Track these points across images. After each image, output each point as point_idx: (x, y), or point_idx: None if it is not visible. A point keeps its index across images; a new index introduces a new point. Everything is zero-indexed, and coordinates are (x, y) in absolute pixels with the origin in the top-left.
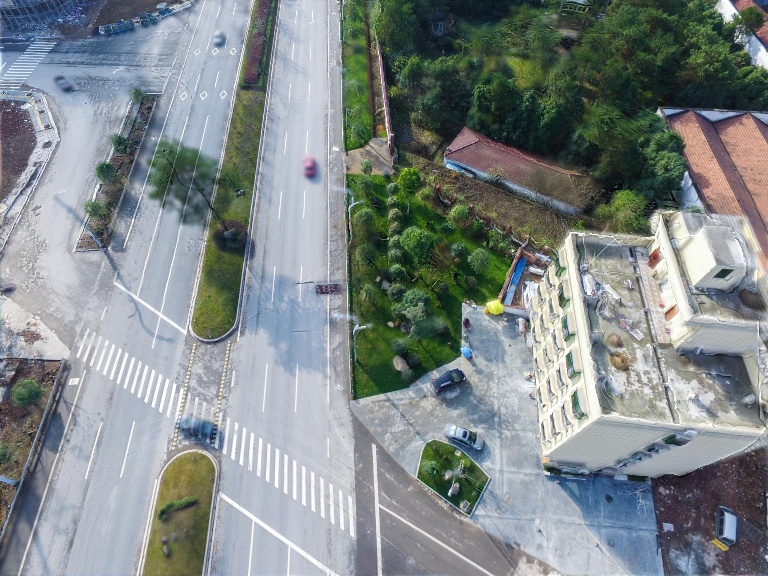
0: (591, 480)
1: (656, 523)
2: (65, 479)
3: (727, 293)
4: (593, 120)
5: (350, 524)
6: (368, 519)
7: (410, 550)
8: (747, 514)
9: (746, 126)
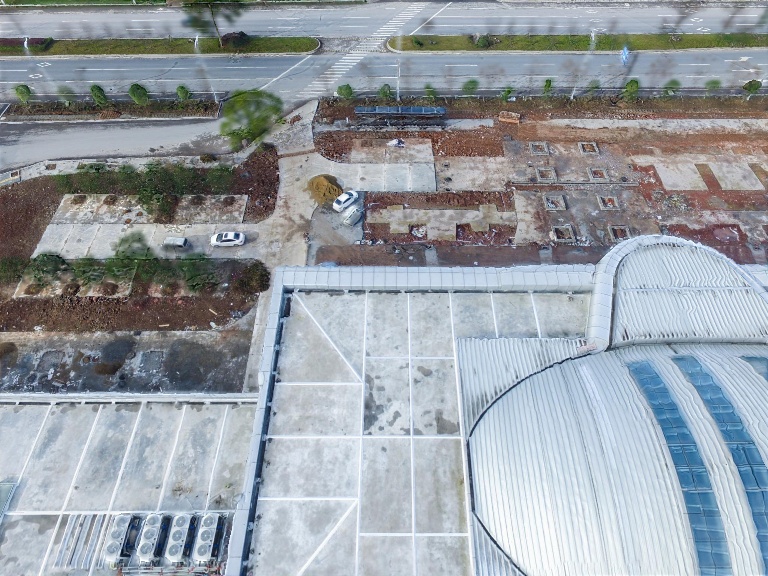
0: None
1: None
2: None
3: None
4: None
5: (426, 3)
6: None
7: None
8: None
9: None
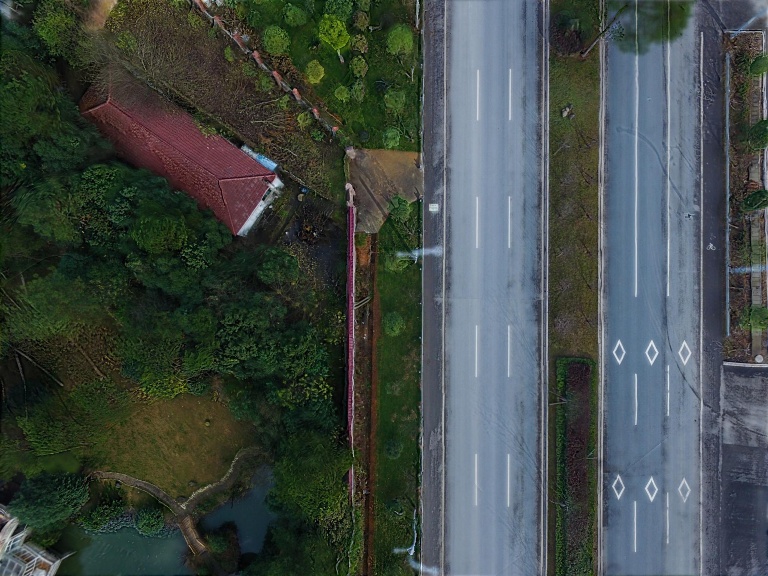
0: None
1: None
2: None
3: None
4: (35, 151)
5: None
6: None
7: None
8: None
9: None
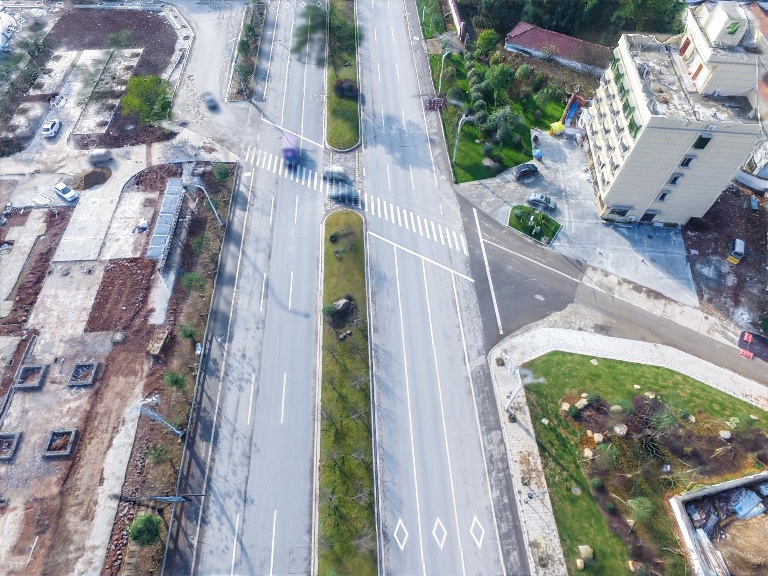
0: (636, 227)
1: (685, 250)
2: (256, 224)
3: (736, 46)
4: None
5: (463, 248)
6: (476, 246)
7: (508, 262)
8: (753, 247)
9: (753, 12)
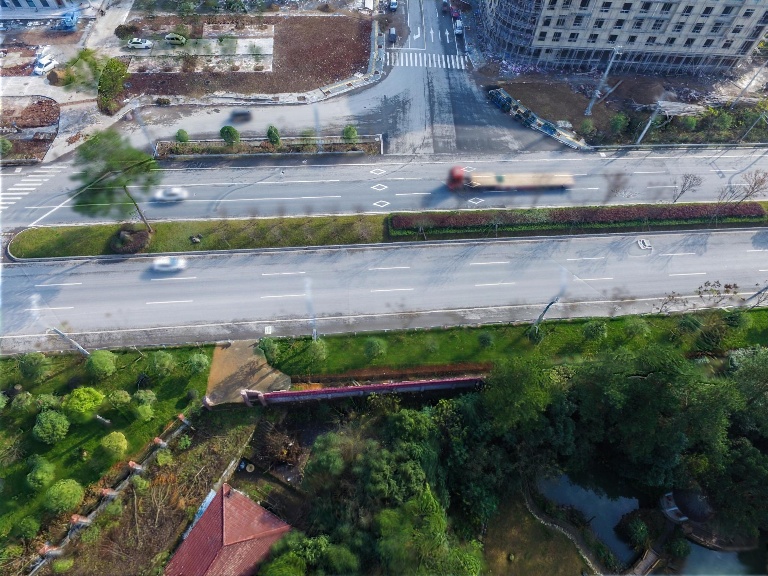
0: None
1: None
2: None
3: None
4: None
5: None
6: None
7: None
8: None
9: None
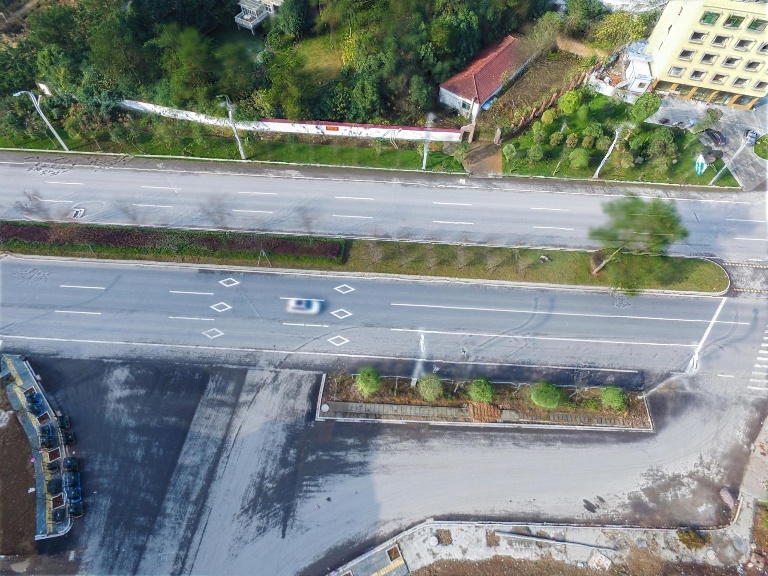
0: None
1: None
2: None
3: None
4: None
5: None
6: None
7: None
8: None
9: None
